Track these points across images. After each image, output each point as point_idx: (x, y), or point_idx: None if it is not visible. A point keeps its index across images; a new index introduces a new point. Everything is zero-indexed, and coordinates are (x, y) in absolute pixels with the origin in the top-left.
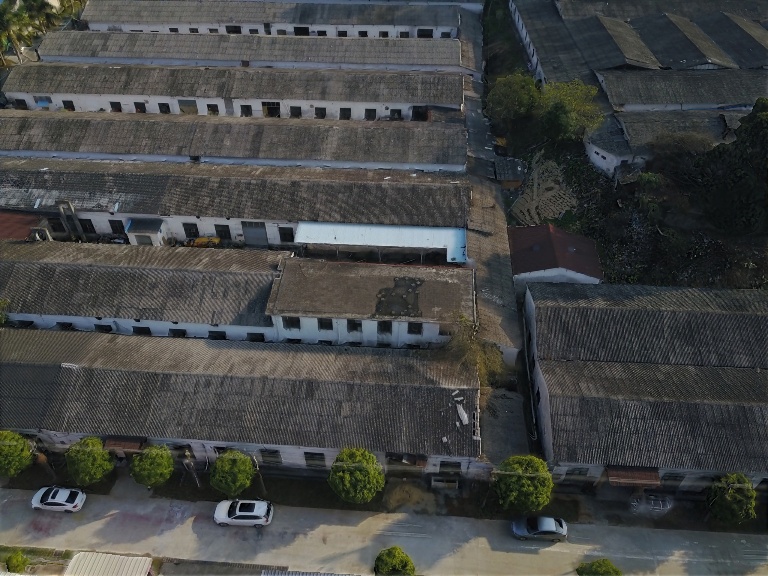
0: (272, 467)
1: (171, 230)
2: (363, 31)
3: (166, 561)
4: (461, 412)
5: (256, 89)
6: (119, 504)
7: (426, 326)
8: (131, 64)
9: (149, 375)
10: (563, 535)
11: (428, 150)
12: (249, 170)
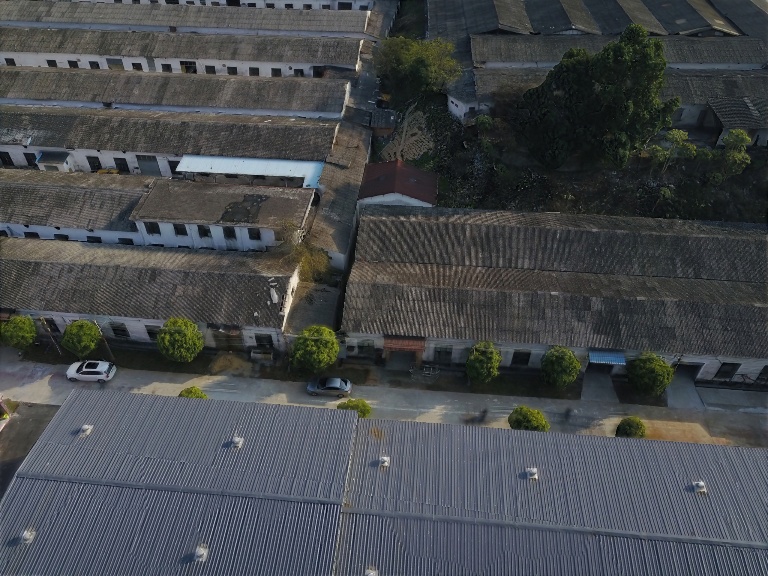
0: (123, 341)
1: (77, 163)
2: (289, 4)
3: (22, 404)
4: (273, 294)
5: (175, 50)
6: None
7: (263, 232)
8: (70, 28)
9: (24, 263)
10: (345, 391)
11: (310, 100)
12: (150, 114)
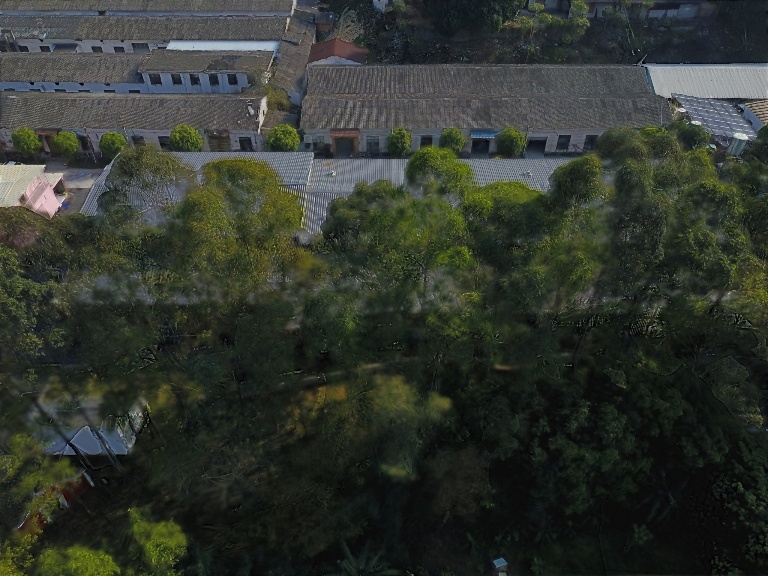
0: None
1: None
2: None
3: (74, 189)
4: (250, 109)
5: None
6: (46, 171)
7: (239, 77)
8: None
9: (63, 100)
10: None
11: (266, 3)
12: None
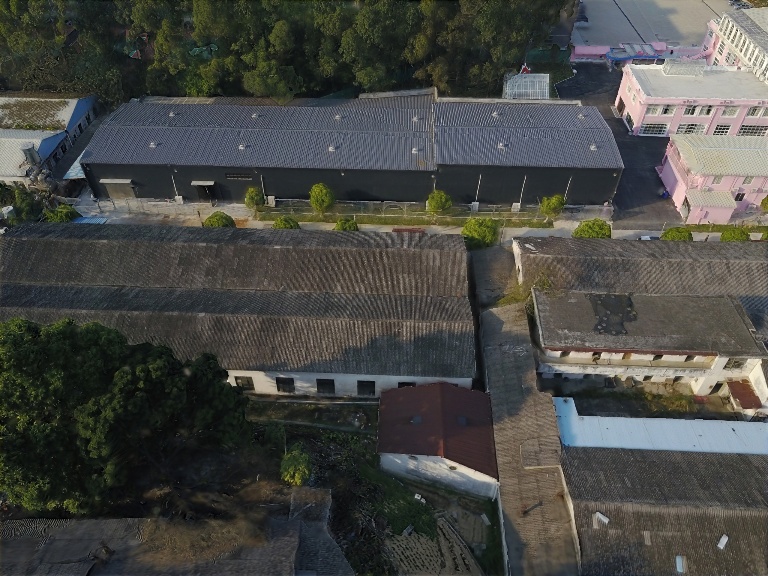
0: None
1: None
2: None
3: None
4: (531, 247)
5: None
6: None
7: None
8: None
9: None
10: None
11: None
12: None
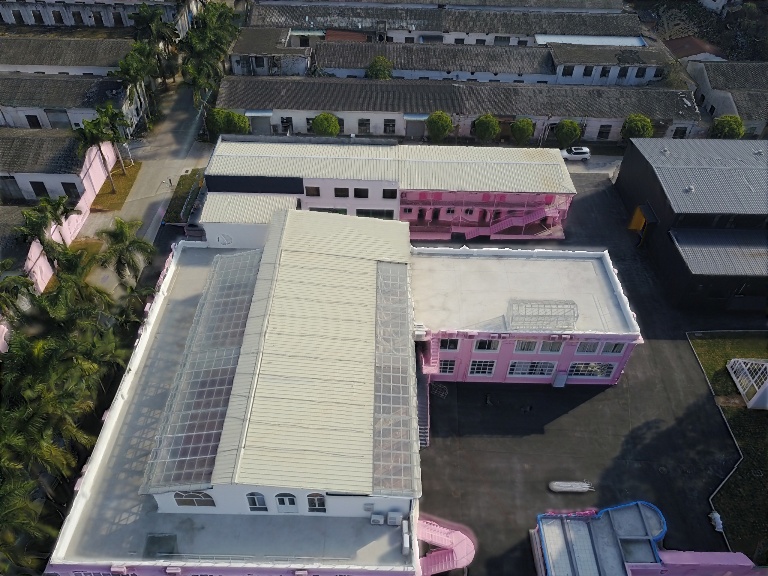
0: None
1: None
2: None
3: None
4: (686, 101)
5: None
6: None
7: (648, 70)
8: None
9: (505, 89)
10: None
11: (597, 1)
12: None
